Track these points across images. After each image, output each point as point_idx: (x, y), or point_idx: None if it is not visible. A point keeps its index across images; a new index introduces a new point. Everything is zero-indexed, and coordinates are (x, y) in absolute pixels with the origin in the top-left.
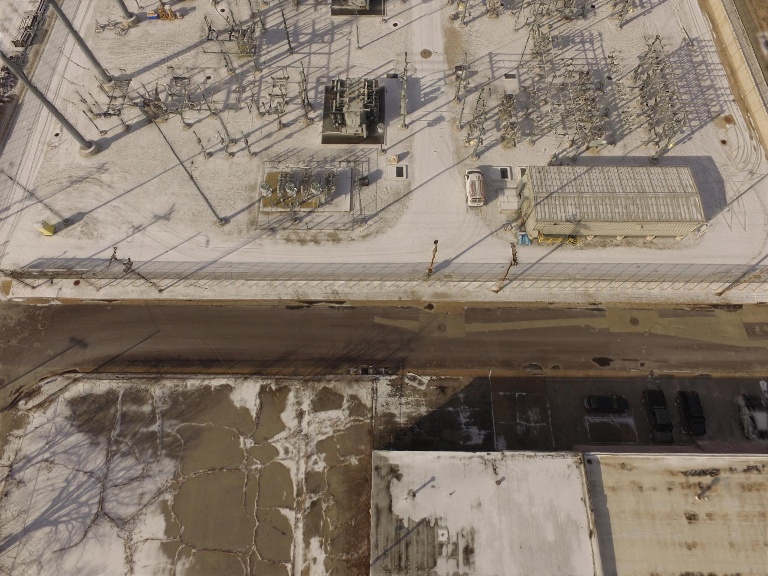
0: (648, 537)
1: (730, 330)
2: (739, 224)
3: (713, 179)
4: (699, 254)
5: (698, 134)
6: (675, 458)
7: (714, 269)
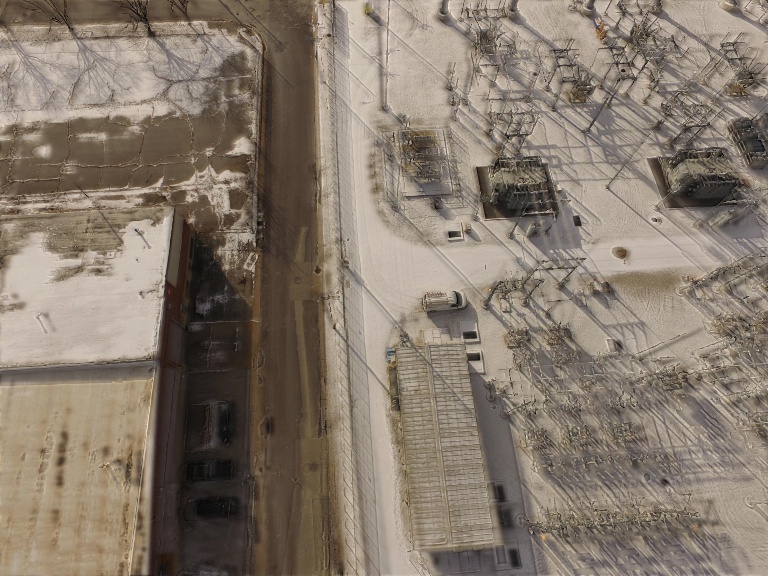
0: (85, 414)
1: None
2: None
3: None
4: (392, 562)
5: None
6: None
7: None
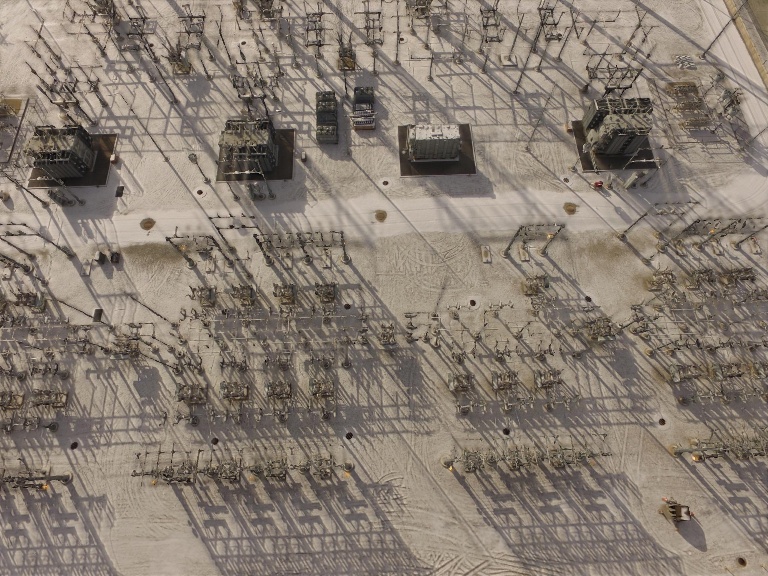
0: None
1: None
2: None
3: None
4: None
5: None
6: None
7: None
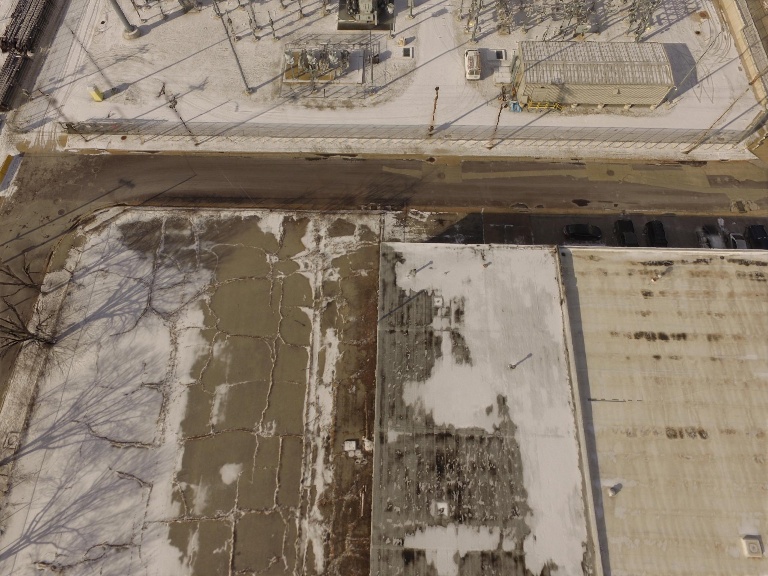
0: (610, 307)
1: (694, 180)
2: (707, 97)
3: (686, 62)
4: (670, 121)
5: (675, 26)
6: (636, 252)
7: (683, 133)
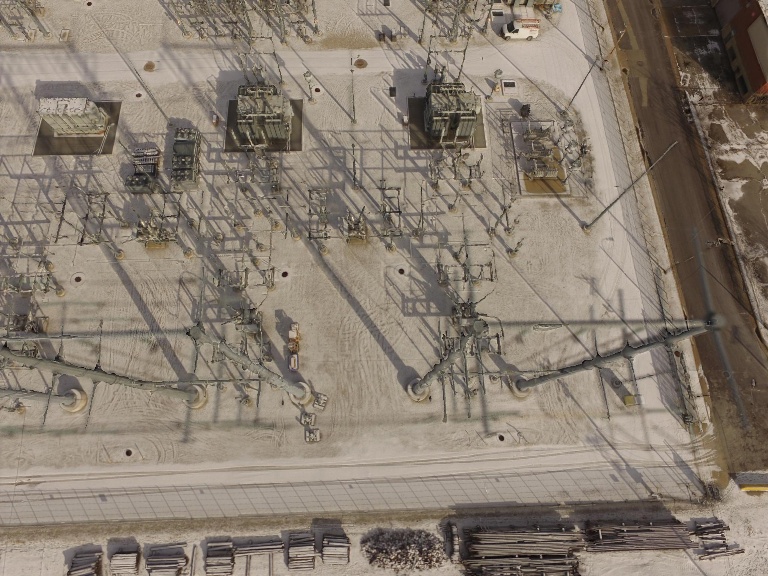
0: None
1: None
2: None
3: None
4: None
5: None
6: None
7: None
